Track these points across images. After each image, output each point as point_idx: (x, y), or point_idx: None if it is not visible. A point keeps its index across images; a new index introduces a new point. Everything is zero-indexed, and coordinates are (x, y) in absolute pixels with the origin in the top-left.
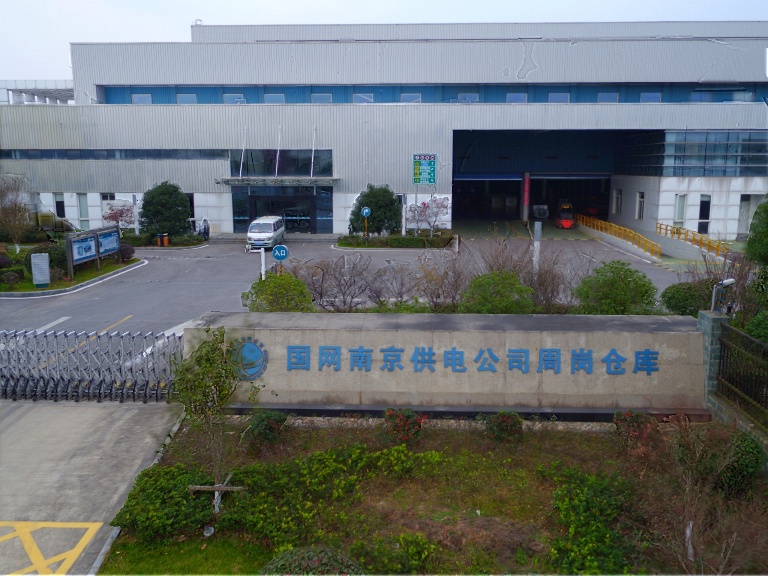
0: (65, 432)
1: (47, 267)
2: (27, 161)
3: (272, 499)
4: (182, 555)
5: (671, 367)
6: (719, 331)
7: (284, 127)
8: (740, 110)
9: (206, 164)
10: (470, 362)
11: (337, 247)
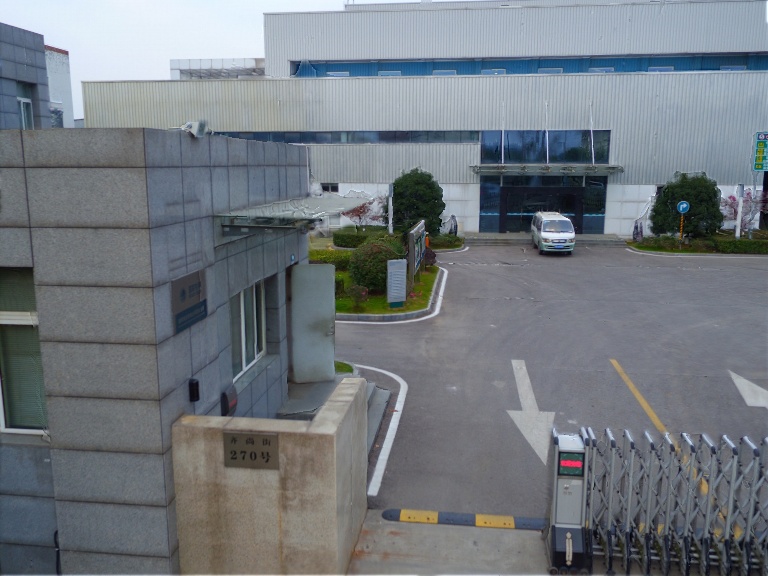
0: None
1: (404, 279)
2: None
3: None
4: None
5: None
6: None
7: (551, 103)
8: None
9: (451, 149)
10: None
11: (644, 251)
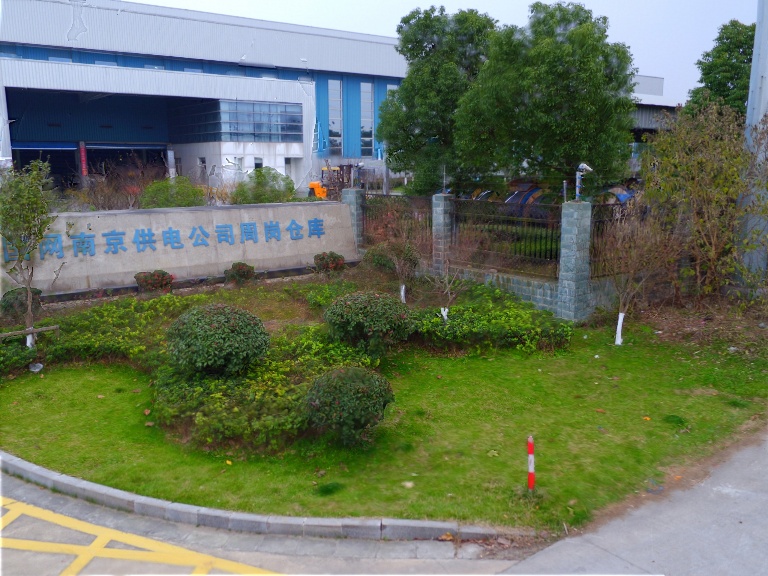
0: None
1: None
2: None
3: (90, 332)
4: (27, 383)
5: (332, 231)
6: (360, 200)
7: None
8: (276, 86)
9: None
10: (186, 239)
11: None
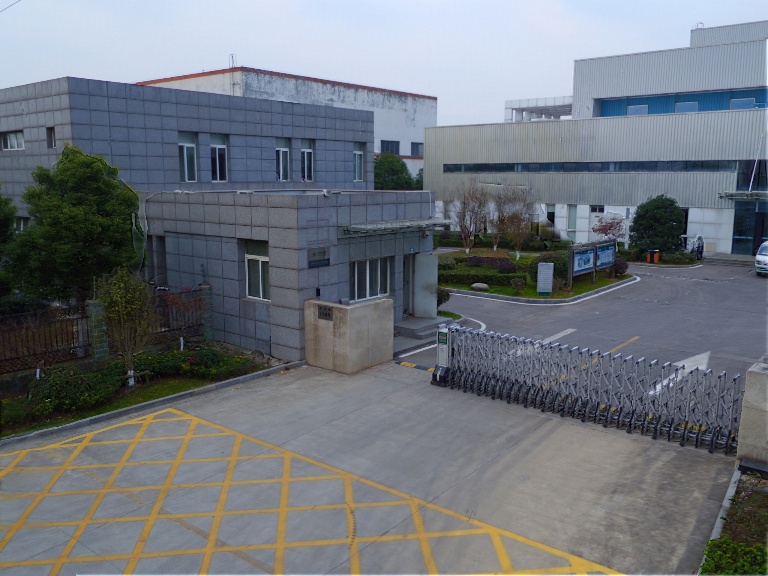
0: (600, 460)
1: (551, 276)
2: (527, 174)
3: None
4: None
5: None
6: None
7: None
8: None
9: (708, 176)
10: None
11: None
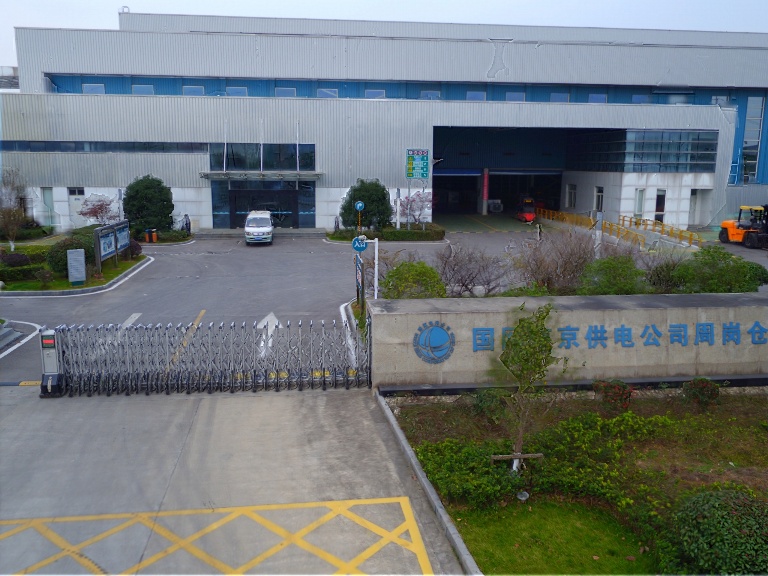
0: (276, 420)
1: (83, 263)
2: None
3: (569, 463)
4: (519, 517)
5: None
6: None
7: (266, 121)
8: (691, 112)
9: (184, 158)
10: (637, 338)
11: (332, 241)
